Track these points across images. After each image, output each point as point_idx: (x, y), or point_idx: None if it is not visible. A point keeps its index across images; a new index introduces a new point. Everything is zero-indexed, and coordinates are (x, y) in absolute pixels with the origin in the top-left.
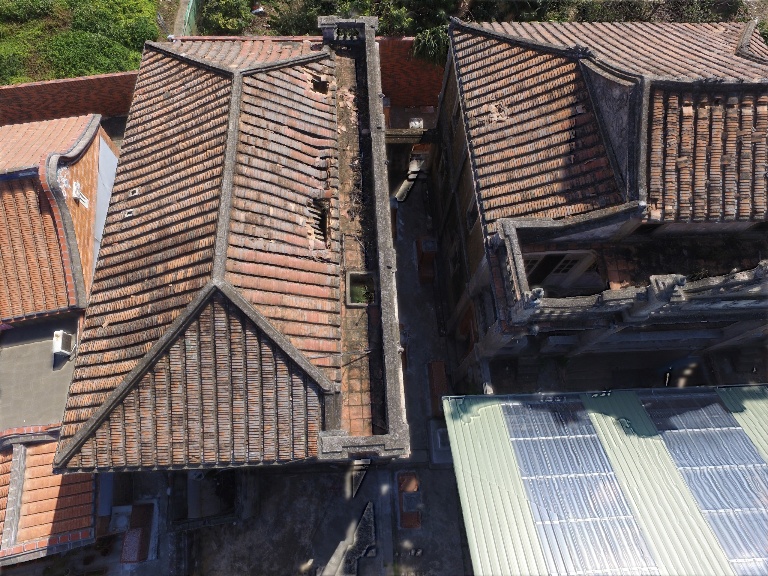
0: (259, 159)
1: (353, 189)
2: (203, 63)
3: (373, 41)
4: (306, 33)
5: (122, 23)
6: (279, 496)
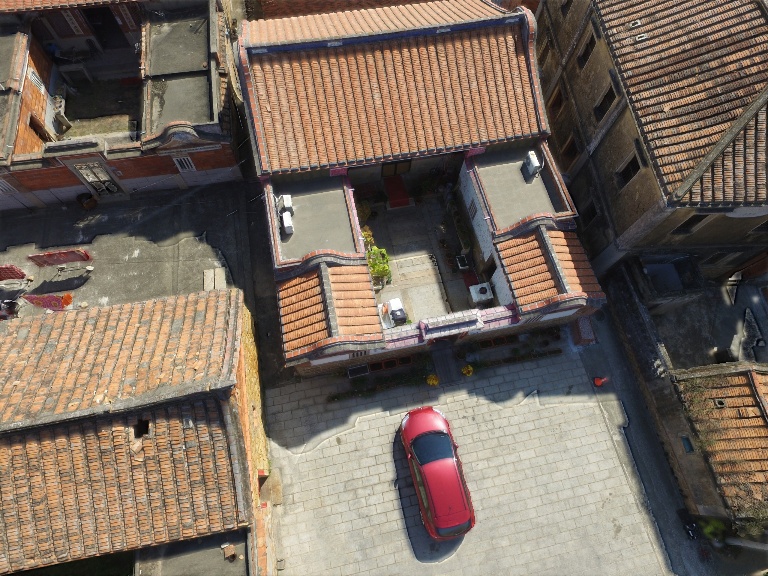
0: None
1: None
2: None
3: None
4: None
5: None
6: None
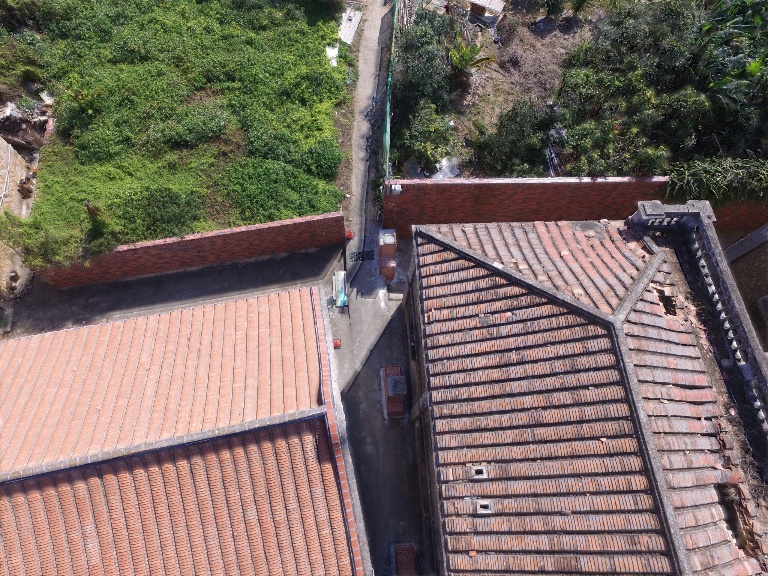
0: (671, 451)
1: (741, 455)
2: (543, 290)
3: (716, 238)
4: (520, 161)
5: (302, 145)
6: None
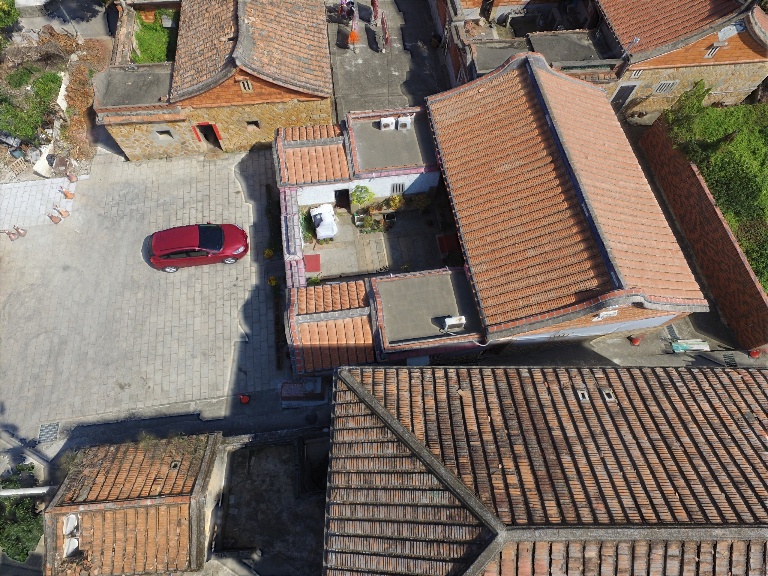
0: (680, 567)
1: None
2: None
3: None
4: None
5: None
6: (319, 518)
